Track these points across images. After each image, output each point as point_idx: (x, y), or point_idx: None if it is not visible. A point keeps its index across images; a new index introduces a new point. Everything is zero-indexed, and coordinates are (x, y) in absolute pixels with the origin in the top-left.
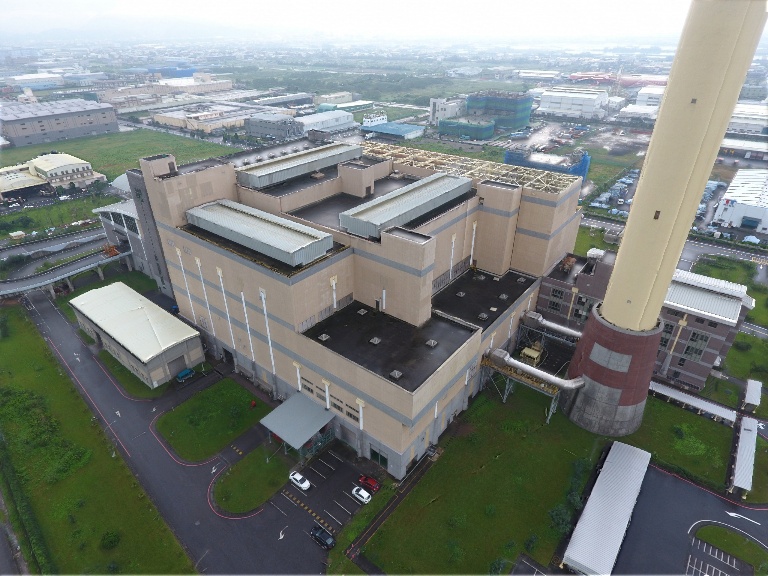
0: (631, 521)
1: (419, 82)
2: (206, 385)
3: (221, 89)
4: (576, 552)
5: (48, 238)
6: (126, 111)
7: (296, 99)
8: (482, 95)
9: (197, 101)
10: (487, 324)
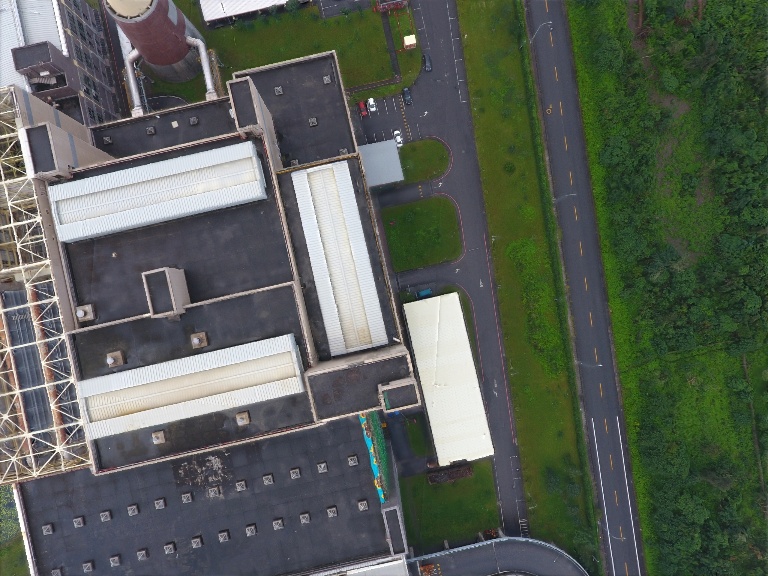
0: None
1: None
2: (413, 273)
3: None
4: None
5: None
6: None
7: None
8: None
9: None
10: (200, 111)
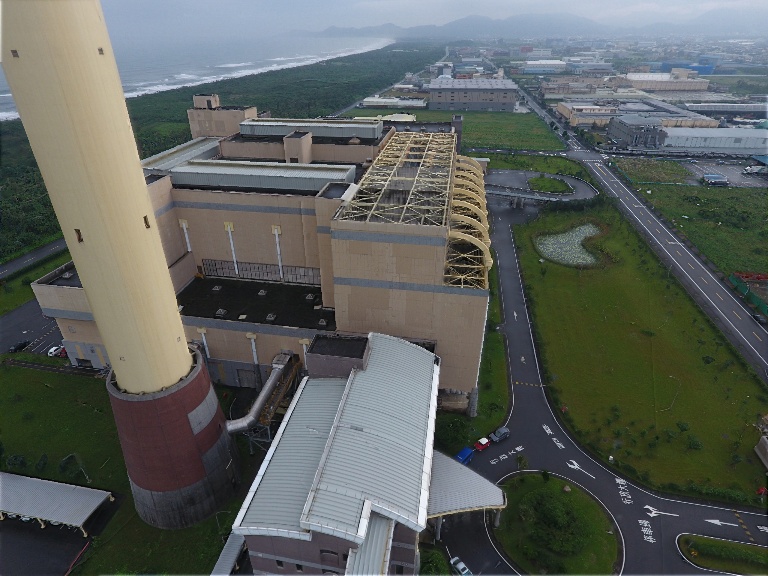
0: (1, 524)
1: None
2: None
3: (689, 89)
4: None
5: None
6: (552, 97)
7: (759, 111)
8: None
9: (637, 97)
10: None
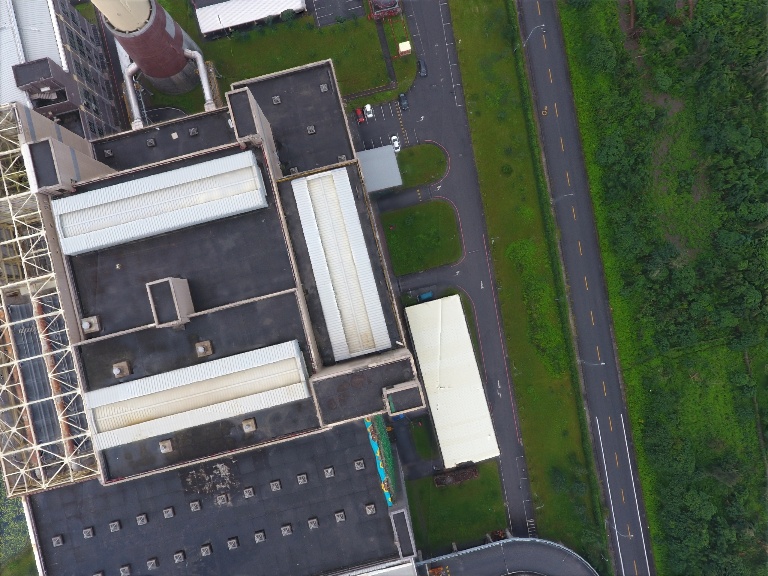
0: None
1: None
2: (414, 277)
3: None
4: (296, 4)
5: None
6: None
7: None
8: None
9: None
10: (200, 122)
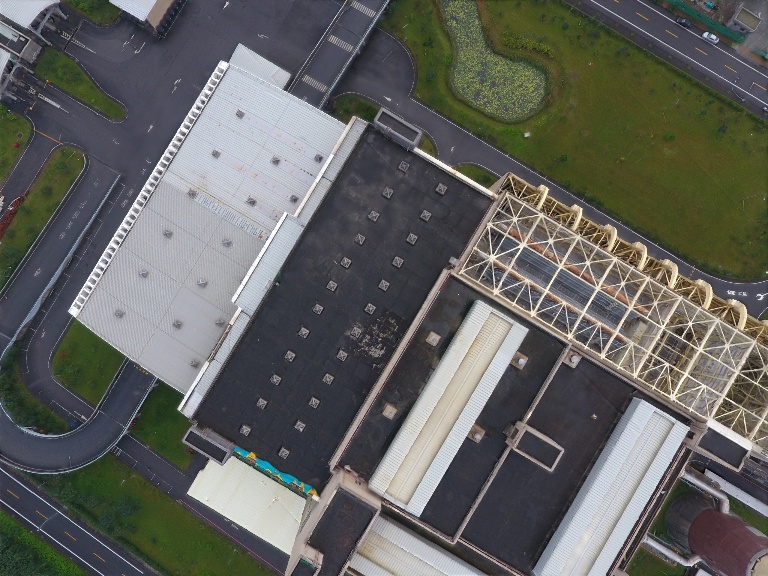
0: None
1: None
2: None
3: None
4: None
5: (1, 292)
6: None
7: None
8: None
9: None
10: None
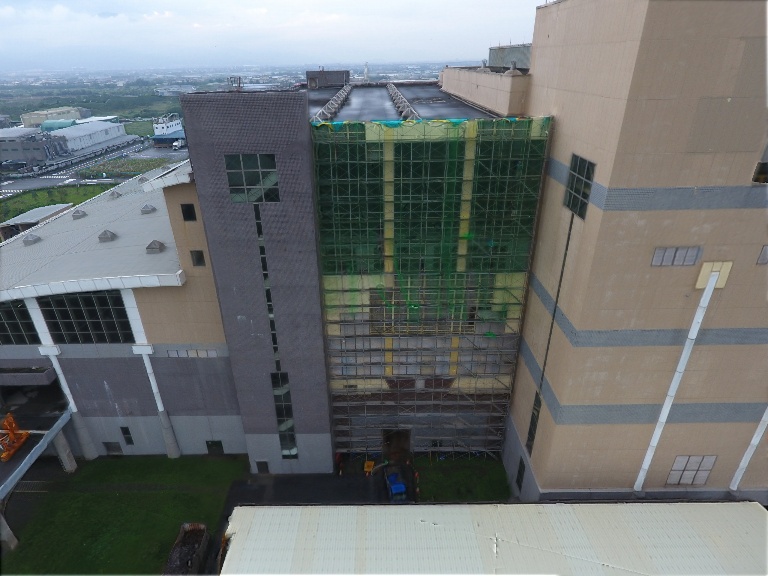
0: None
1: (139, 99)
2: None
3: None
4: None
5: None
6: None
7: None
8: (283, 88)
9: None
10: None
